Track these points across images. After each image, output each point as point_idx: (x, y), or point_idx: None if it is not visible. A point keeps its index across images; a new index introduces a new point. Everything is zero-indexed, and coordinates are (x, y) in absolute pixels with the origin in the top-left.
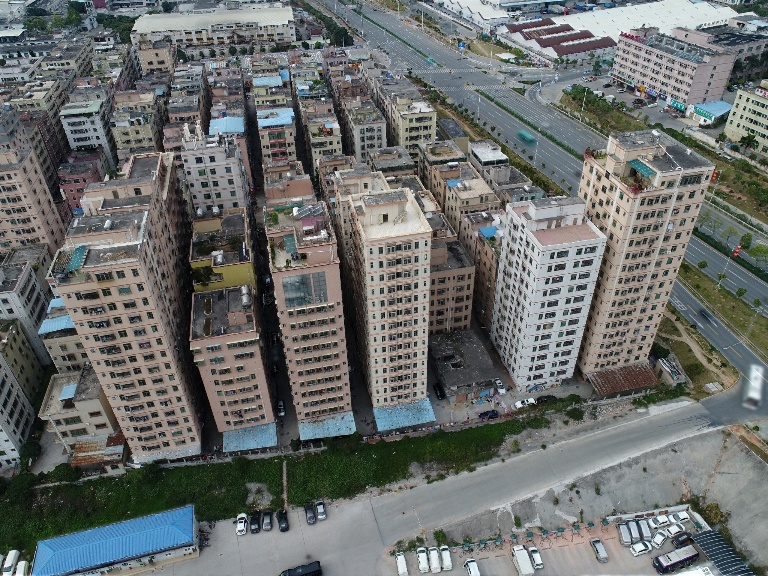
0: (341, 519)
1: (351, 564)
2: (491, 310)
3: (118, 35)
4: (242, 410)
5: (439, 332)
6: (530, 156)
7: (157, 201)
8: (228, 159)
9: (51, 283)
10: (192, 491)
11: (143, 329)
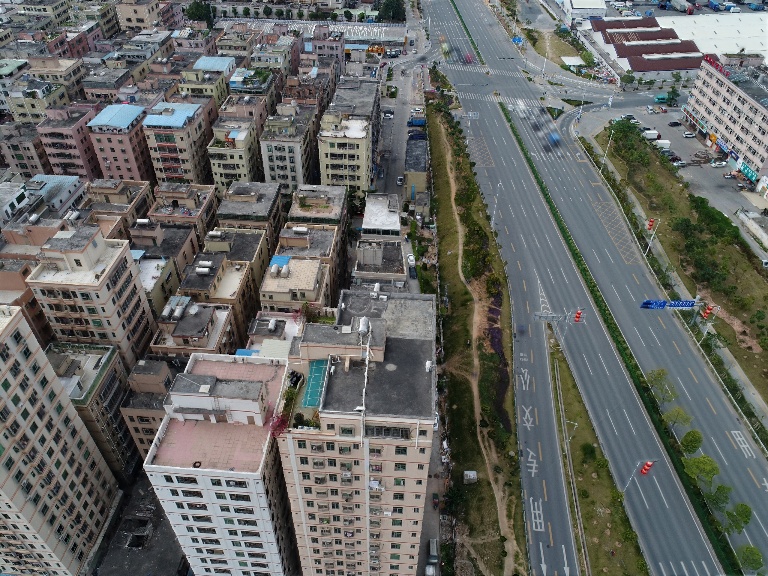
0: None
1: None
2: None
3: None
4: None
5: None
6: (487, 215)
7: None
8: None
9: None
10: None
11: None
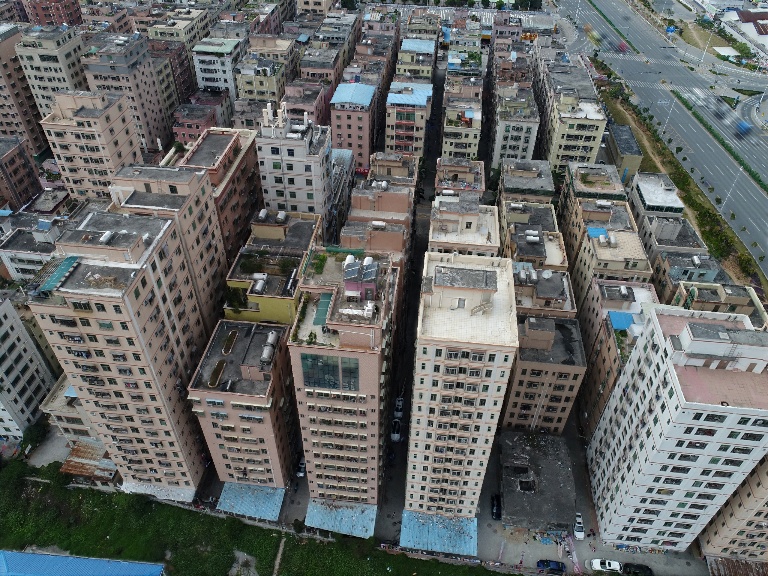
0: None
1: None
2: (596, 421)
3: None
4: (247, 468)
5: (520, 426)
6: (718, 199)
7: (198, 203)
8: (309, 156)
9: None
10: (176, 538)
11: (128, 369)
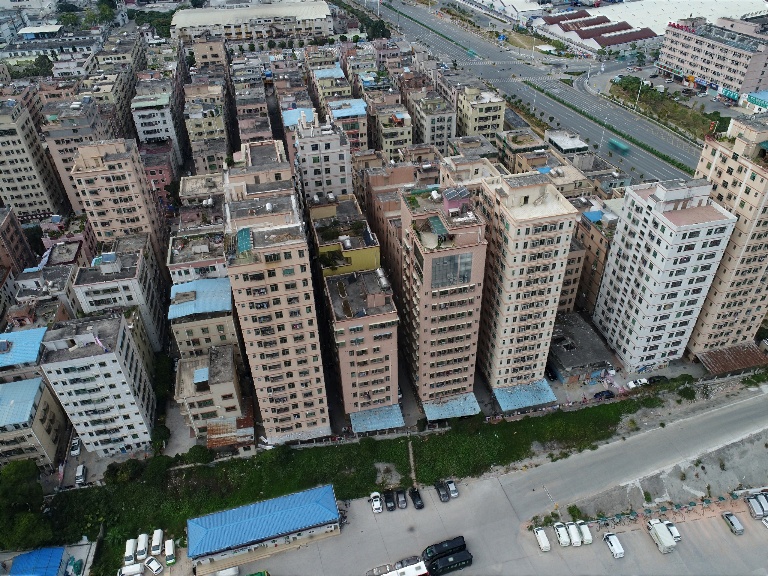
0: (473, 497)
1: (491, 539)
2: (595, 293)
3: (155, 30)
4: (371, 391)
5: None
6: (595, 145)
7: None
8: (342, 146)
9: (171, 270)
10: (323, 471)
11: (299, 310)
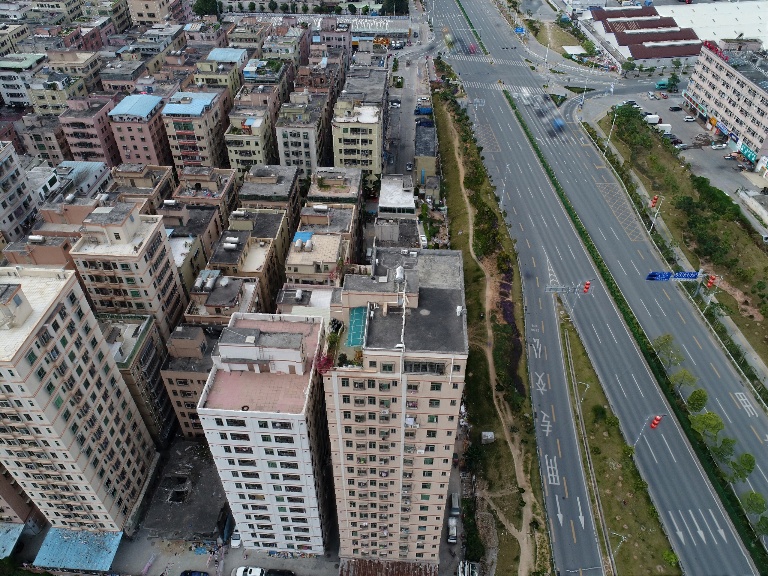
0: None
1: None
2: None
3: None
4: None
5: (201, 436)
6: (496, 197)
7: None
8: None
9: None
10: None
11: None
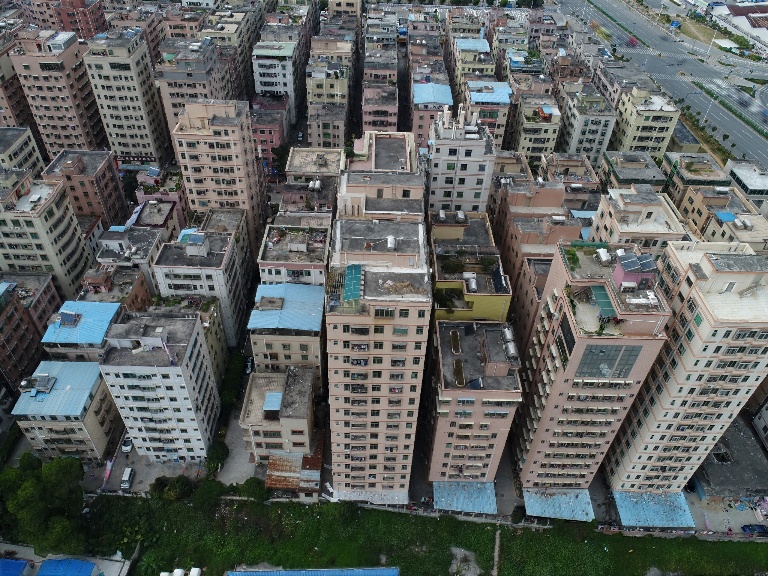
0: None
1: None
2: (766, 392)
3: None
4: (465, 465)
5: None
6: None
7: None
8: (486, 155)
9: (262, 267)
10: (390, 542)
11: (402, 374)
